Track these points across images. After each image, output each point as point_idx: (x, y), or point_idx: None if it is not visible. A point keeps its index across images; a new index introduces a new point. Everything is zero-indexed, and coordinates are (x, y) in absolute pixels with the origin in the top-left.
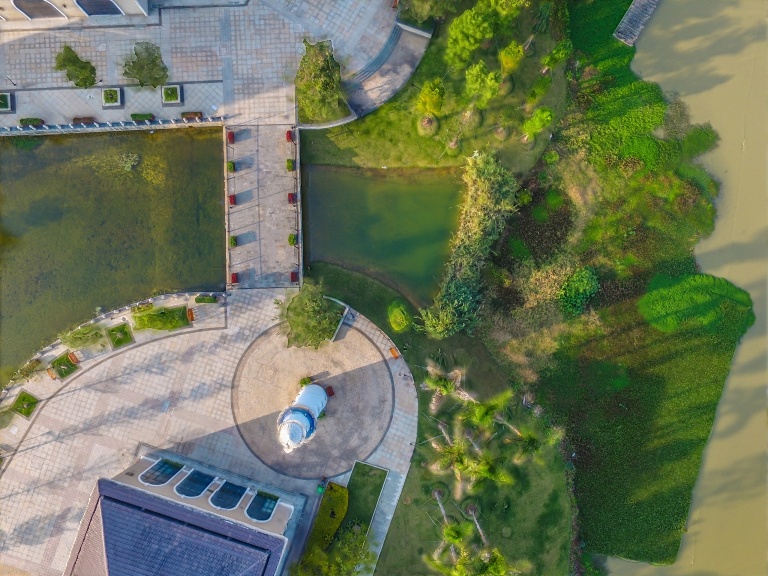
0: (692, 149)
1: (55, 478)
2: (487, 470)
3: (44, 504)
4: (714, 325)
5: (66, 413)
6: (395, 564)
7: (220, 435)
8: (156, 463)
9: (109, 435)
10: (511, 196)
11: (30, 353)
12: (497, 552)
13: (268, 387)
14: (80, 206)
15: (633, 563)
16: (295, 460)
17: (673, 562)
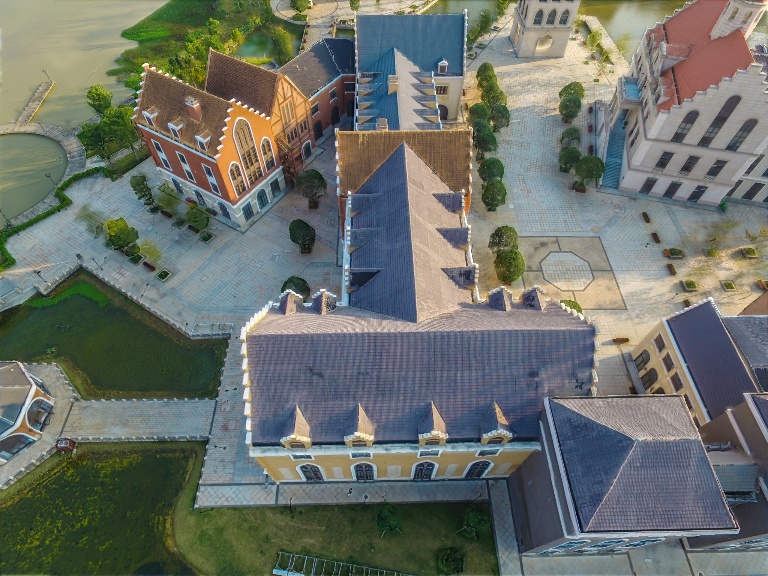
0: None
1: None
2: None
3: None
4: None
5: (399, 5)
6: None
7: None
8: None
9: None
10: None
11: None
12: None
13: (324, 8)
14: None
15: None
16: None
17: None
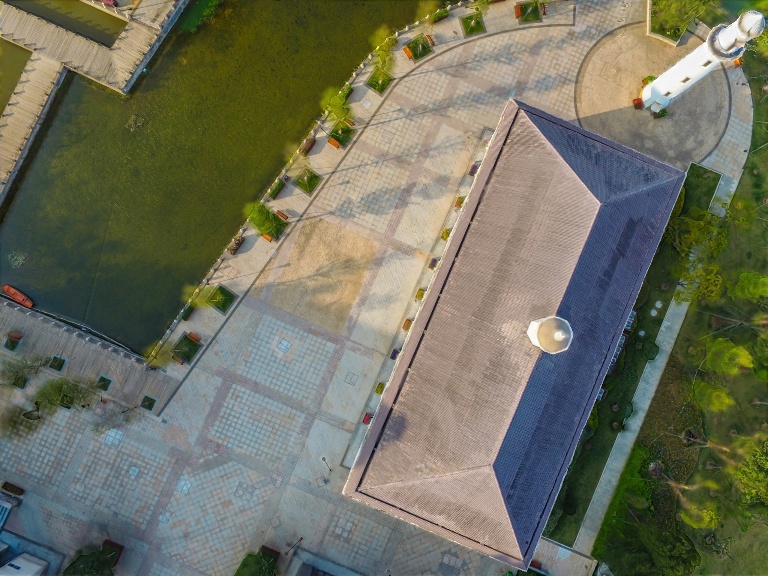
0: None
1: (403, 153)
2: None
3: (391, 177)
4: None
5: (417, 93)
6: (724, 265)
7: None
8: None
9: (456, 117)
10: None
11: (380, 39)
12: None
13: (610, 85)
14: None
15: None
16: None
17: None
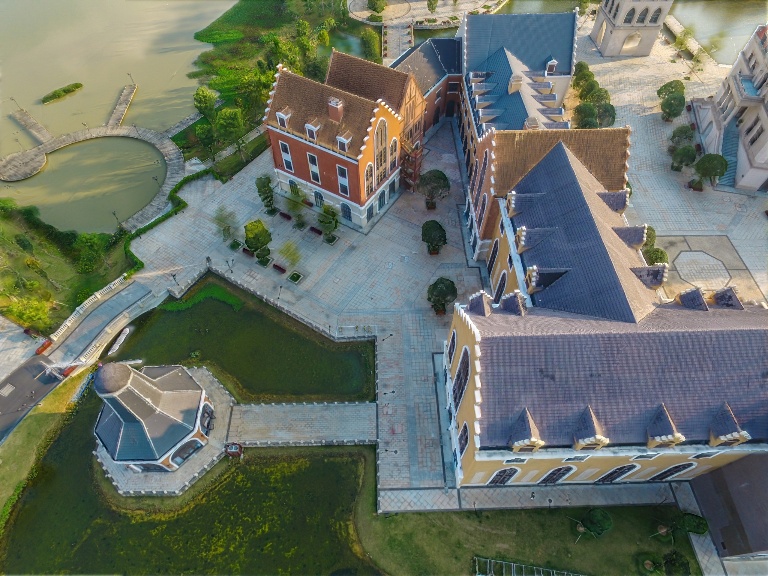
0: (201, 71)
1: None
2: None
3: None
4: None
5: None
6: None
7: (415, 1)
8: None
9: None
10: None
11: None
12: None
13: None
14: None
15: None
16: None
17: None
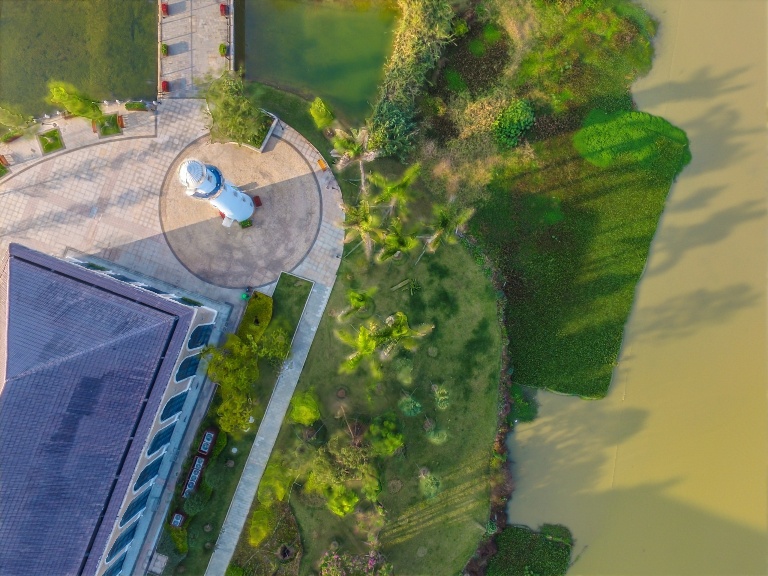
0: None
1: None
2: (396, 240)
3: None
4: (649, 161)
5: None
6: (318, 375)
7: (147, 242)
8: (81, 262)
9: (37, 239)
10: (447, 25)
11: None
12: (401, 313)
13: None
14: (16, 18)
15: (564, 397)
16: (221, 269)
17: (604, 396)
